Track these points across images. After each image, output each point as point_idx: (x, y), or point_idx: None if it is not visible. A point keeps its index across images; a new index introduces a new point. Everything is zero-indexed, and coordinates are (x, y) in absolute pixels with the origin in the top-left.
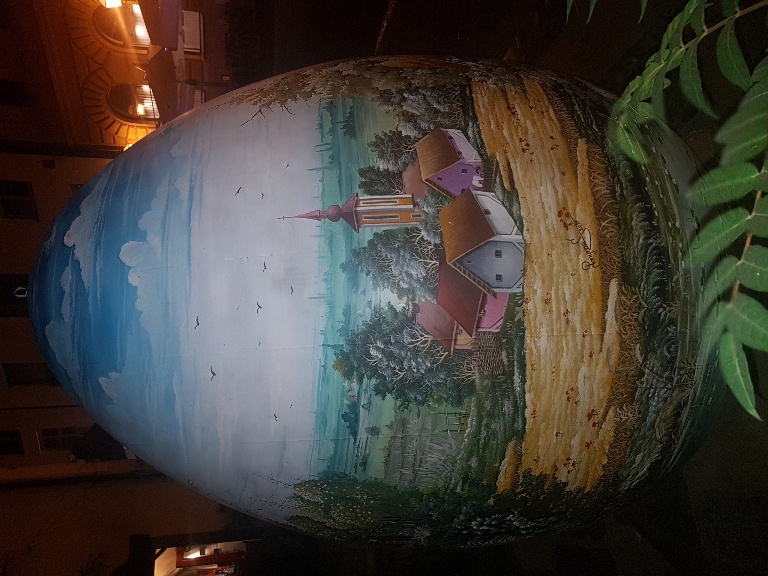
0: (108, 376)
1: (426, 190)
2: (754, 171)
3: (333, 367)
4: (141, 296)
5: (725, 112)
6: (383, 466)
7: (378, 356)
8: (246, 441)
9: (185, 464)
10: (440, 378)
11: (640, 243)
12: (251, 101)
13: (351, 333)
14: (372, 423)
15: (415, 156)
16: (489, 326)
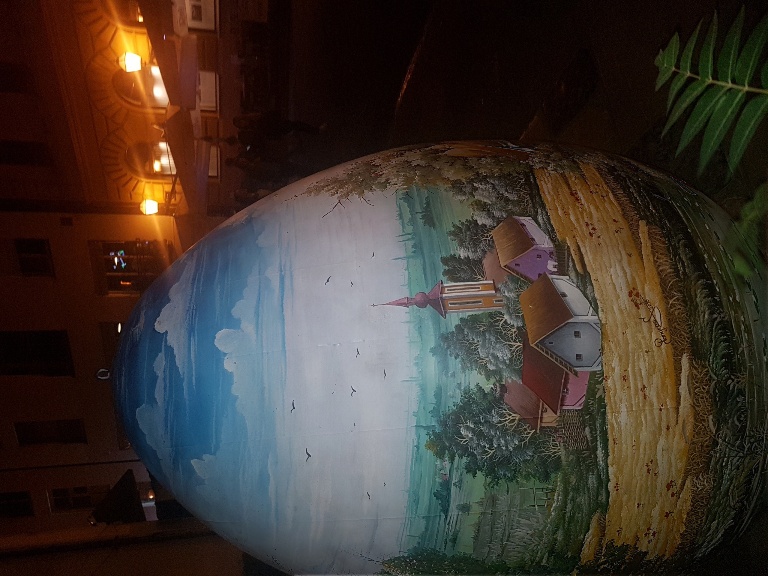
0: (201, 458)
1: (506, 276)
2: None
3: (426, 447)
4: (237, 381)
5: (759, 181)
6: (472, 541)
7: (469, 435)
8: (338, 519)
9: (273, 542)
10: (528, 455)
11: (706, 318)
12: (328, 192)
13: (442, 414)
14: (463, 500)
15: (492, 244)
16: (572, 404)
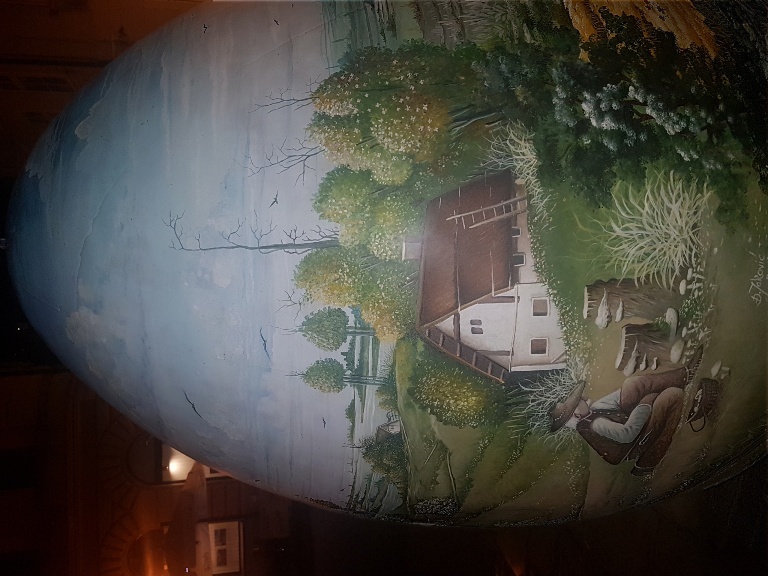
0: (87, 115)
1: None
2: None
3: None
4: (138, 43)
5: None
6: (416, 23)
7: None
8: None
9: (167, 164)
10: None
11: None
12: None
13: None
14: None
15: None
16: None
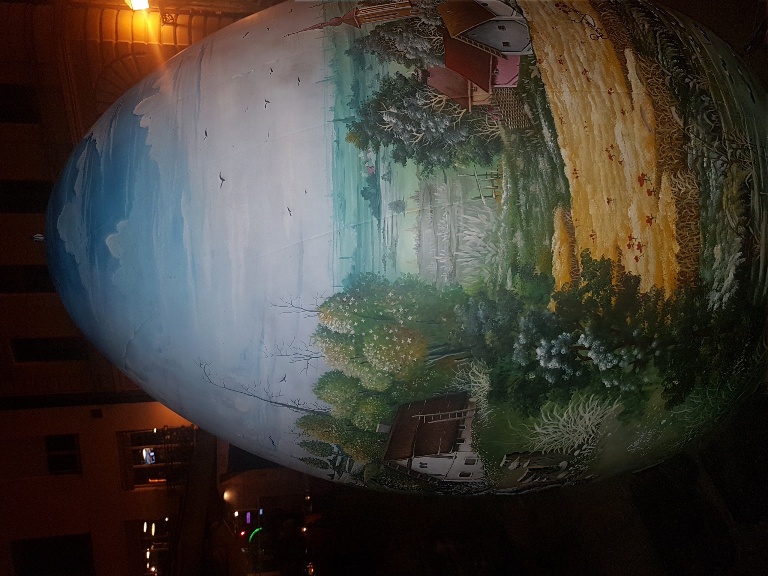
0: (115, 230)
1: None
2: (756, 66)
3: (346, 140)
4: (151, 132)
5: None
6: (415, 254)
7: (392, 121)
8: (260, 255)
9: (195, 324)
10: (462, 136)
11: (646, 28)
12: None
13: (362, 104)
14: (395, 196)
15: None
16: (505, 83)
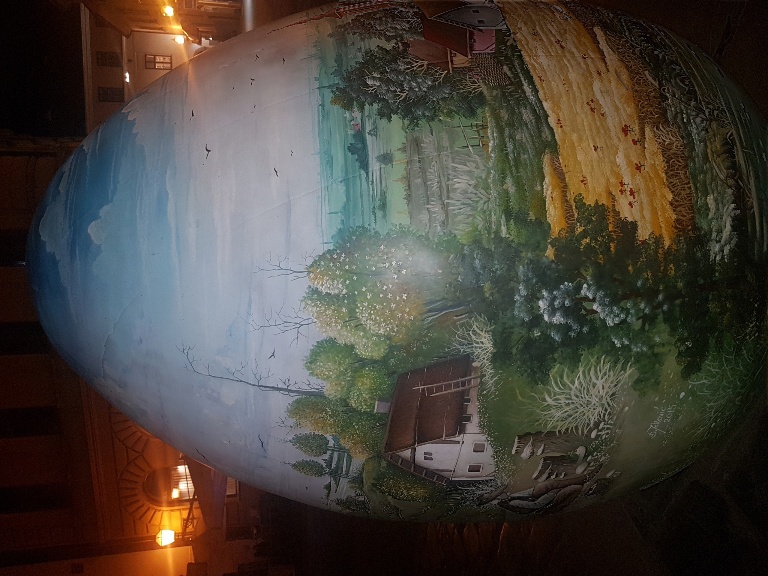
0: (98, 216)
1: None
2: None
3: (331, 103)
4: (139, 122)
5: None
6: (406, 204)
7: (376, 84)
8: (246, 218)
9: (178, 301)
10: (445, 93)
11: None
12: None
13: (345, 72)
14: (382, 150)
15: None
16: (482, 49)
